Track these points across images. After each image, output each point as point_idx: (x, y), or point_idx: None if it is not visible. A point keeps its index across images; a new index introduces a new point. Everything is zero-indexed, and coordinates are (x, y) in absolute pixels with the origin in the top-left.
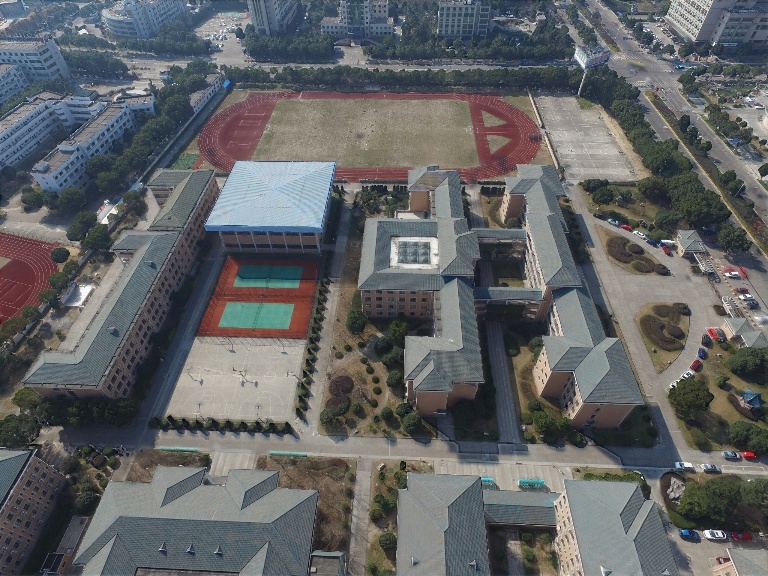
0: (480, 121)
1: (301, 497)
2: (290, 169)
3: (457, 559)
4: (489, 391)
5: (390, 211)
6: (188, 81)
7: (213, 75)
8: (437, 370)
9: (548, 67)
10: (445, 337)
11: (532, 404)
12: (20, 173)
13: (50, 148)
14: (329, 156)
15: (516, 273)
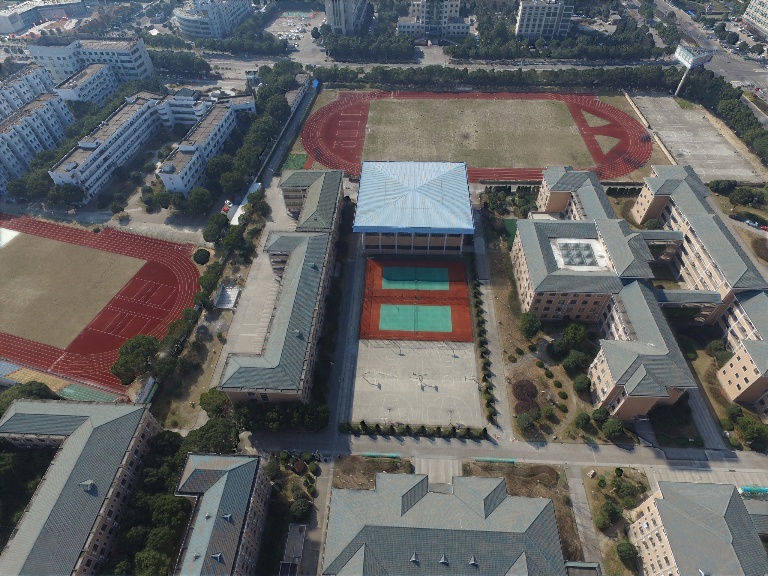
0: (583, 121)
1: (539, 505)
2: (422, 169)
3: (752, 572)
4: (684, 396)
5: (522, 212)
6: (281, 81)
7: (302, 75)
8: (650, 375)
9: (644, 67)
10: (642, 341)
11: (734, 410)
12: (134, 173)
13: (154, 148)
14: (440, 156)
15: (668, 275)
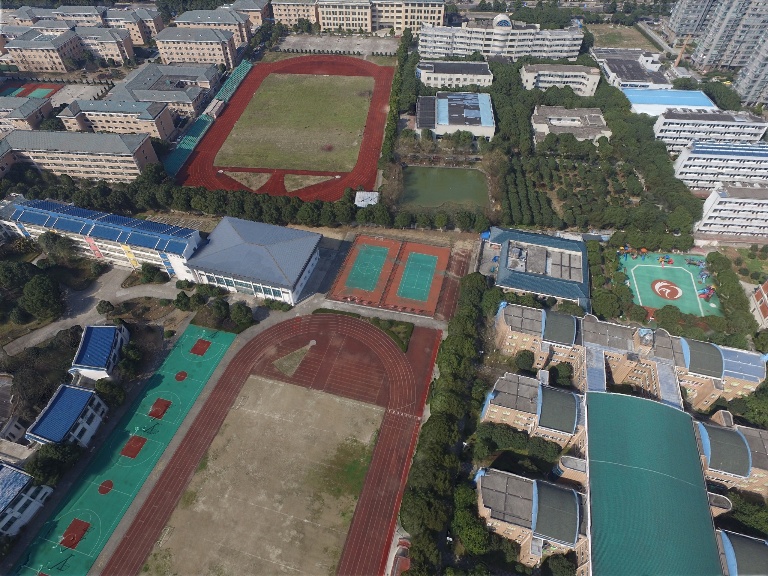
0: None
1: None
2: None
3: None
4: None
5: None
6: None
7: None
8: None
9: None
10: None
11: (146, 40)
12: None
13: None
14: None
15: None
